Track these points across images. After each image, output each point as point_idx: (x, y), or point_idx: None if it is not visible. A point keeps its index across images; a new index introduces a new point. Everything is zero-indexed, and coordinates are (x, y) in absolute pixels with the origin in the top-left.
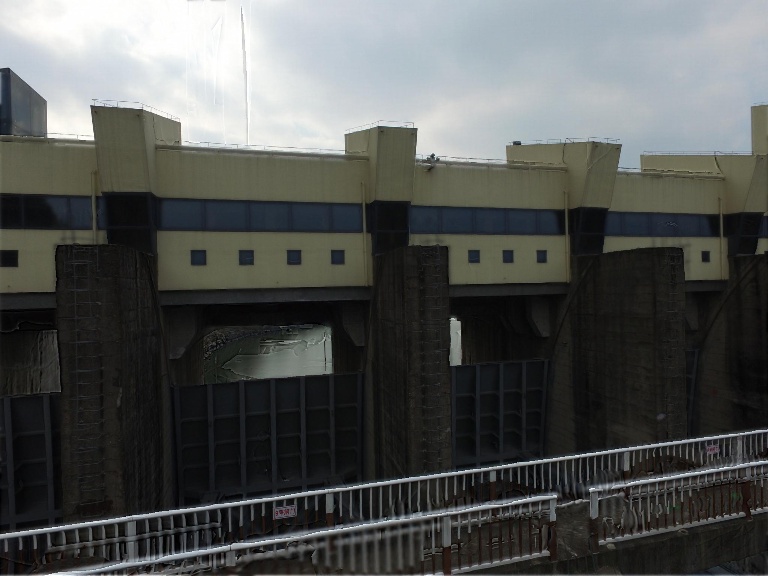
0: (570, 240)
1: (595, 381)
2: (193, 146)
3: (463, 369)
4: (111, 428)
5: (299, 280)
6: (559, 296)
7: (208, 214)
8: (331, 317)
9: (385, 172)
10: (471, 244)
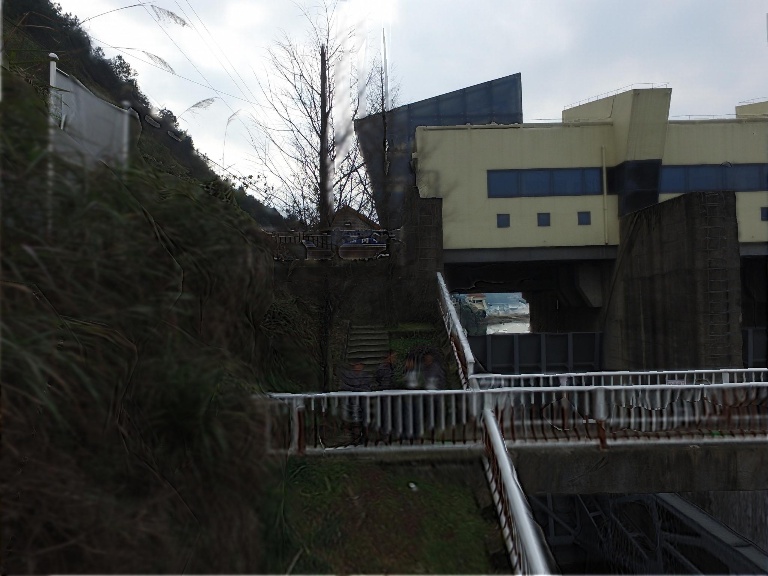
0: None
1: None
2: (677, 120)
3: None
4: (735, 340)
5: None
6: None
7: (688, 178)
8: (741, 279)
9: None
10: None
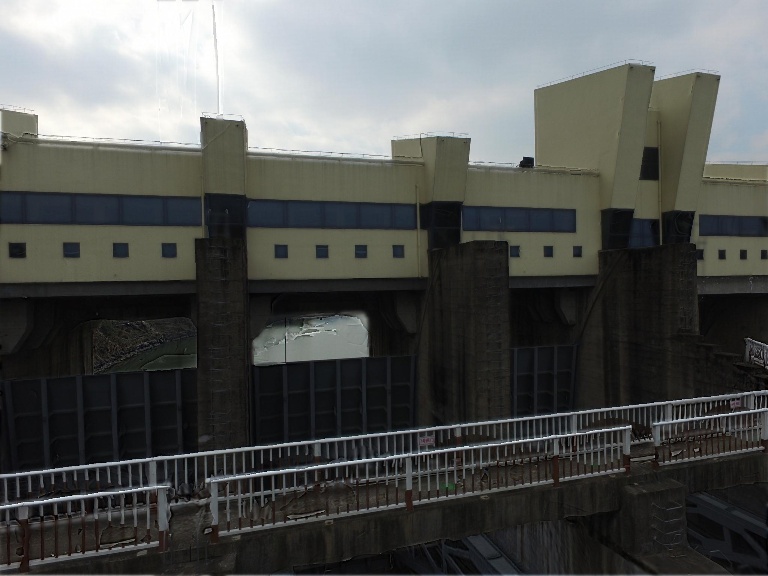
0: None
1: None
2: None
3: (95, 379)
4: None
5: None
6: None
7: None
8: None
9: None
10: (68, 235)
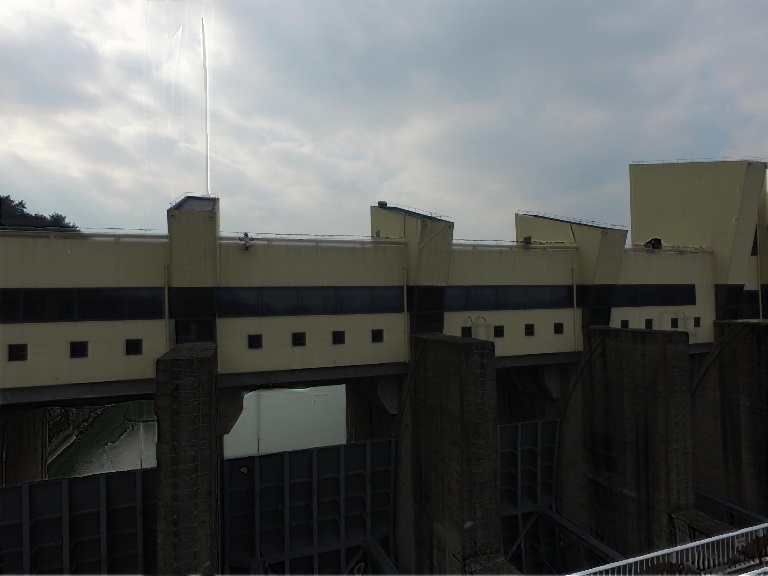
0: (410, 317)
1: (425, 472)
2: None
3: (298, 454)
4: None
5: (85, 374)
6: (402, 374)
7: None
8: None
9: (181, 257)
10: (296, 326)
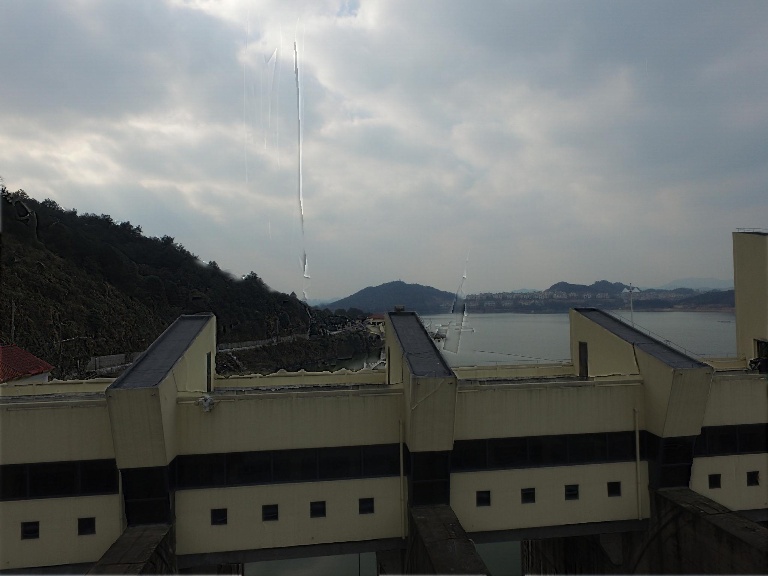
0: (407, 482)
1: None
2: None
3: None
4: None
5: (36, 557)
6: None
7: None
8: None
9: (125, 438)
10: (267, 497)
